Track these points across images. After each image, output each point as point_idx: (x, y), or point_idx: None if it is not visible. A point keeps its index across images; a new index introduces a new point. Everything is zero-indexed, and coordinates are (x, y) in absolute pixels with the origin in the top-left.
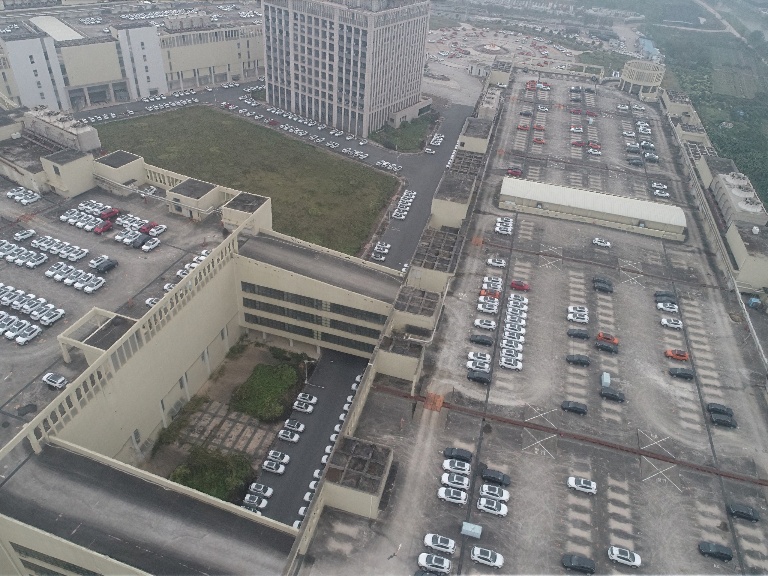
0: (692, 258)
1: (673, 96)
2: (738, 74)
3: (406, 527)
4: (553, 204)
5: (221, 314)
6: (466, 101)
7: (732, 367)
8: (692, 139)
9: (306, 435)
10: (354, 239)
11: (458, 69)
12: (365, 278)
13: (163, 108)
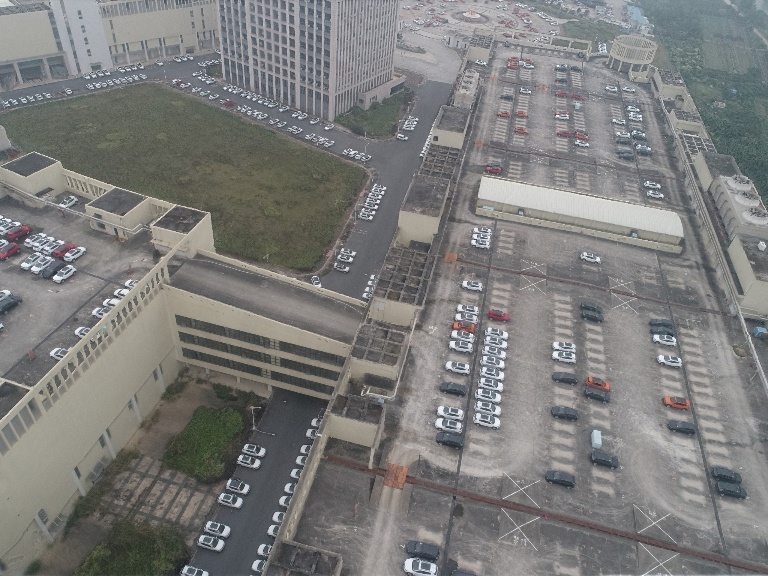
0: (690, 275)
1: (666, 77)
2: (729, 46)
3: None
4: (536, 210)
5: (152, 353)
6: (443, 77)
7: (738, 416)
8: (687, 128)
9: (251, 498)
10: (315, 245)
11: (435, 40)
12: (320, 310)
13: (106, 86)
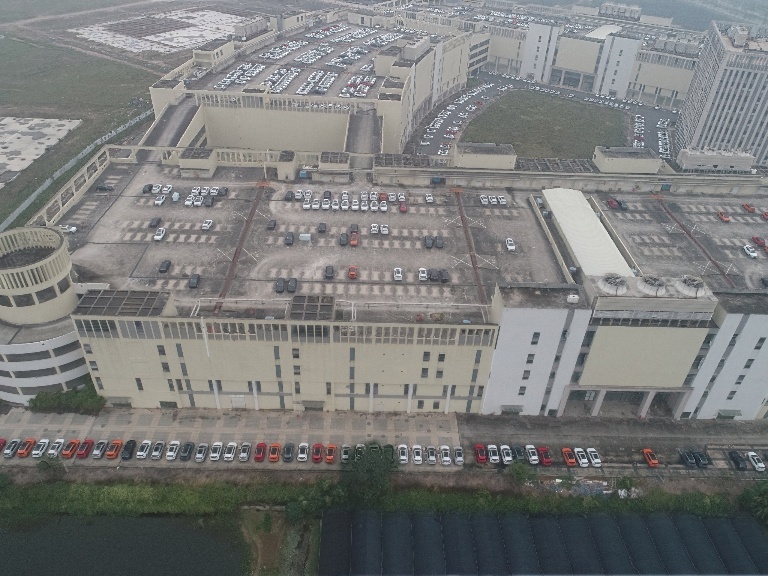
0: None
1: None
2: None
3: (178, 183)
4: None
5: (333, 143)
6: None
7: None
8: None
9: None
10: None
11: None
12: None
13: (596, 102)
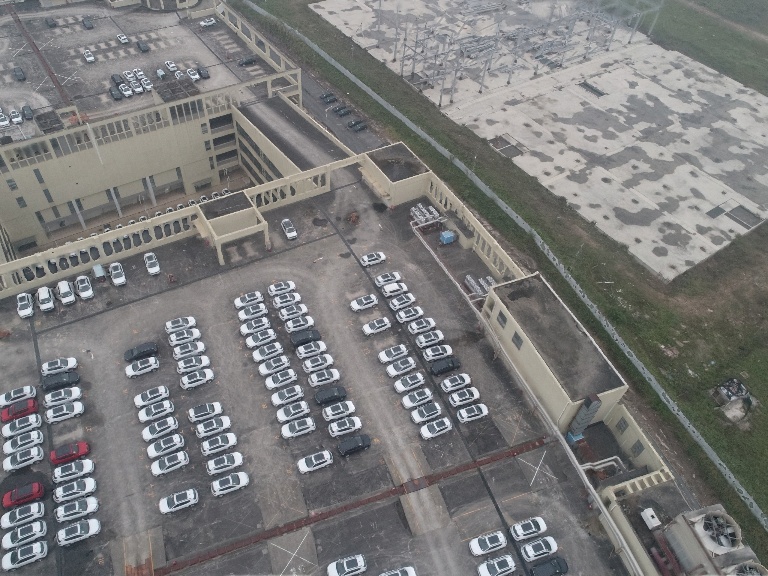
0: None
1: None
2: None
3: None
4: None
5: None
6: None
7: None
8: None
9: None
10: None
11: None
12: None
13: None
